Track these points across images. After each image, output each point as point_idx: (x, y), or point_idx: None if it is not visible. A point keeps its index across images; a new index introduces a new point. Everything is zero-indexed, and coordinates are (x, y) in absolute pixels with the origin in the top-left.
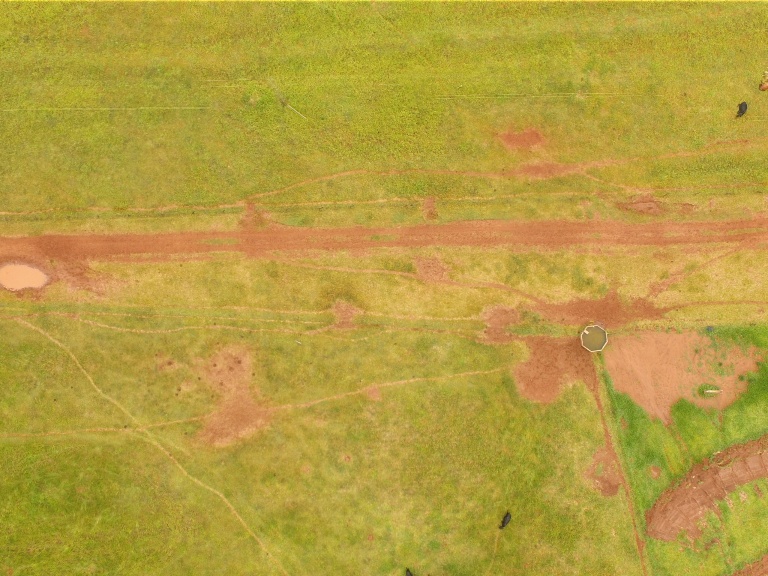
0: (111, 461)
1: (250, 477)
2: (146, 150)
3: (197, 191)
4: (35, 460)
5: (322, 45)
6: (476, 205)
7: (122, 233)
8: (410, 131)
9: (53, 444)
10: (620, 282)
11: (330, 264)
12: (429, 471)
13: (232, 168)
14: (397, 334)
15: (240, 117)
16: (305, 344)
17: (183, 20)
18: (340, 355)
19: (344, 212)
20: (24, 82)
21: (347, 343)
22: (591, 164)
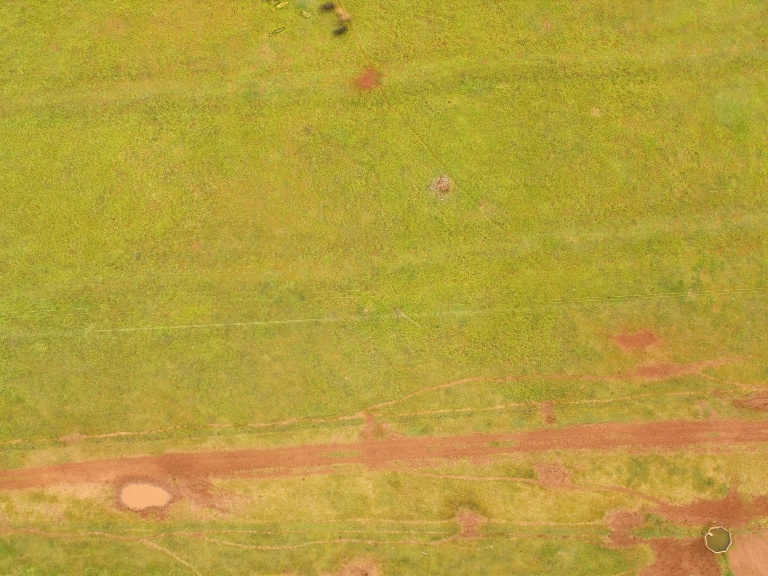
0: None
1: None
2: (263, 364)
3: (316, 404)
4: None
5: (433, 253)
6: (594, 408)
7: (243, 449)
8: (525, 337)
9: None
10: (740, 480)
11: (452, 473)
12: None
13: (349, 379)
14: (522, 541)
15: (355, 328)
16: (431, 555)
17: (293, 232)
18: (466, 564)
19: (463, 420)
20: (138, 300)
21: (473, 552)
22: (706, 363)
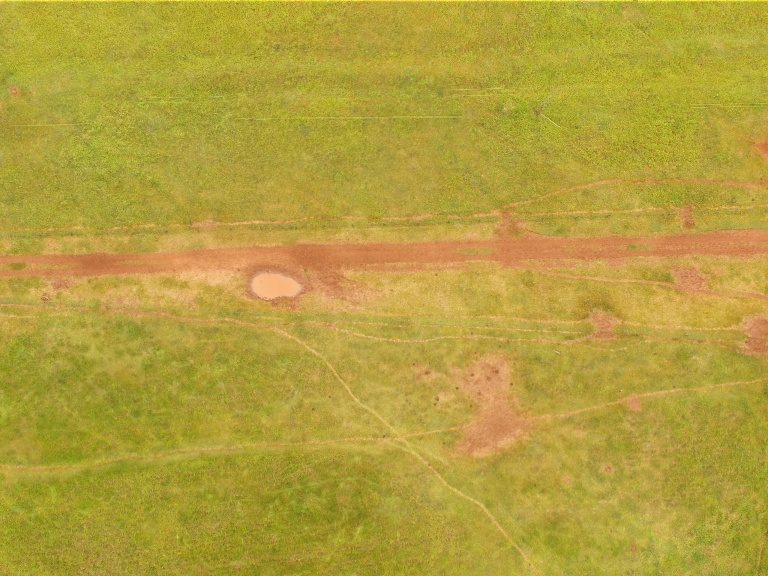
0: (371, 471)
1: (510, 487)
2: (399, 159)
3: (451, 200)
4: (295, 469)
5: (575, 54)
6: (733, 214)
7: (376, 242)
8: (666, 140)
9: (312, 453)
10: None
11: (587, 274)
12: (692, 482)
13: (486, 177)
14: (657, 344)
15: (494, 126)
16: (563, 354)
17: (434, 29)
18: (599, 365)
19: (600, 221)
20: (276, 91)
21: (606, 353)
22: None
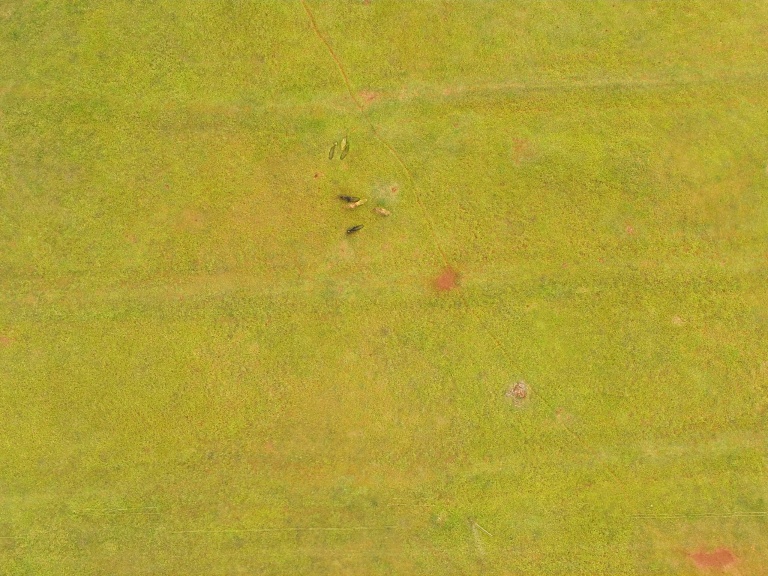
0: None
1: None
2: (334, 571)
3: None
4: None
5: (509, 462)
6: None
7: None
8: (601, 552)
9: None
10: None
11: None
12: None
13: None
14: None
15: (428, 537)
16: None
17: (368, 435)
18: None
19: None
20: (210, 501)
21: None
22: None
